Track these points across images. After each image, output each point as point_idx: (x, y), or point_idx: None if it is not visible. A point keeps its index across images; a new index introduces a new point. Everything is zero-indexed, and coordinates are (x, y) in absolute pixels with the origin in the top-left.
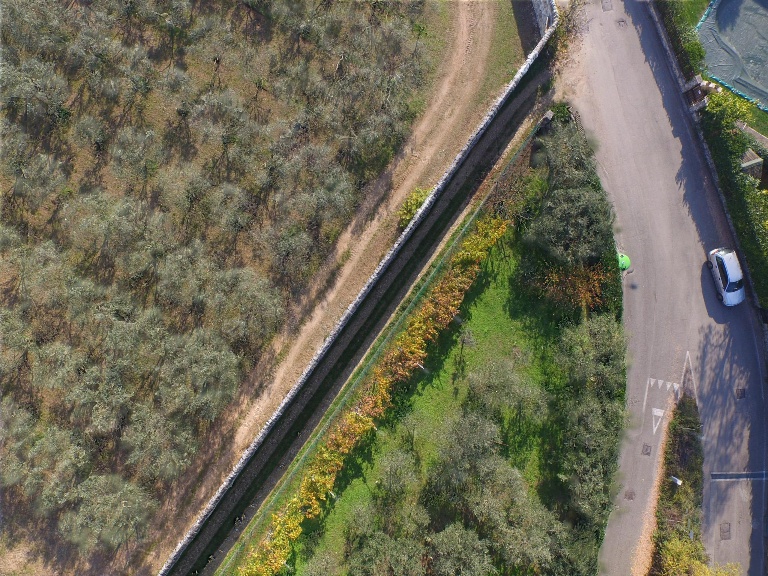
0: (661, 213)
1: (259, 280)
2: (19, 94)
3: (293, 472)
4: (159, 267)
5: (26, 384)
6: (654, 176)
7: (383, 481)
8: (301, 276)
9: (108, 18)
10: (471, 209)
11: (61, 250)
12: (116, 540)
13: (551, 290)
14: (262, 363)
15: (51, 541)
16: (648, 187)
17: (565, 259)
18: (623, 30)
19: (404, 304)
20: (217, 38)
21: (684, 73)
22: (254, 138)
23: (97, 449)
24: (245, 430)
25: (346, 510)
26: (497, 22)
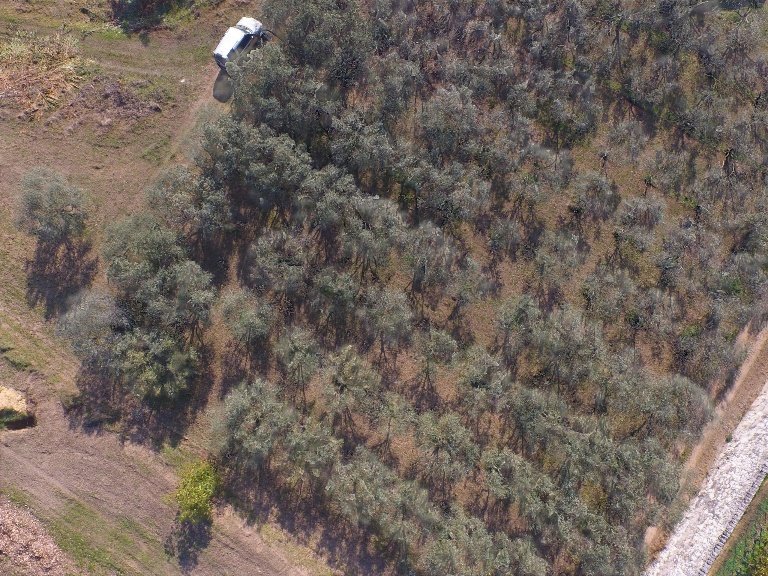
0: None
1: (659, 379)
2: None
3: None
4: (560, 365)
5: (438, 482)
6: None
7: None
8: (701, 376)
9: (490, 112)
10: None
11: (463, 347)
12: None
13: None
14: None
15: None
16: None
17: None
18: None
19: None
20: (601, 133)
21: None
22: (645, 235)
23: (514, 549)
24: (654, 530)
25: None
26: None
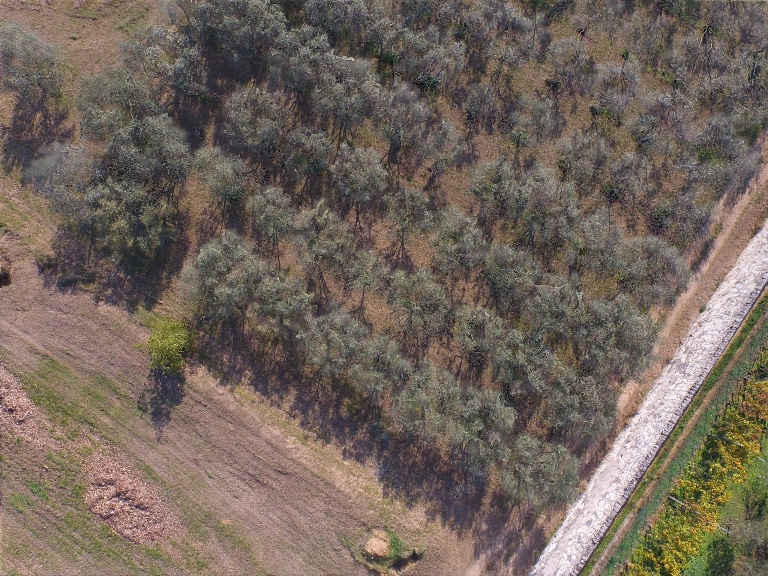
0: None
1: (634, 250)
2: None
3: (685, 440)
4: (535, 236)
5: (412, 348)
6: None
7: None
8: (675, 247)
9: None
10: None
11: (438, 217)
12: (509, 502)
13: None
14: None
15: (447, 501)
16: None
17: None
18: None
19: None
20: (579, 10)
21: None
22: (622, 110)
23: (486, 413)
24: (626, 398)
25: None
26: None
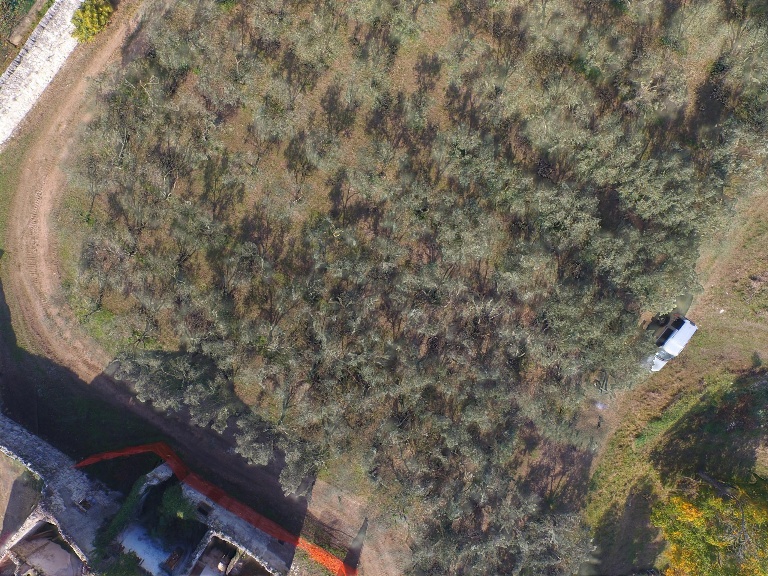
0: None
1: None
2: None
3: None
4: None
5: None
6: None
7: None
8: None
9: (410, 257)
10: None
11: (461, 5)
12: None
13: None
14: None
15: None
16: None
17: None
18: None
19: None
20: (298, 226)
21: None
22: None
23: None
24: None
25: None
26: (6, 222)
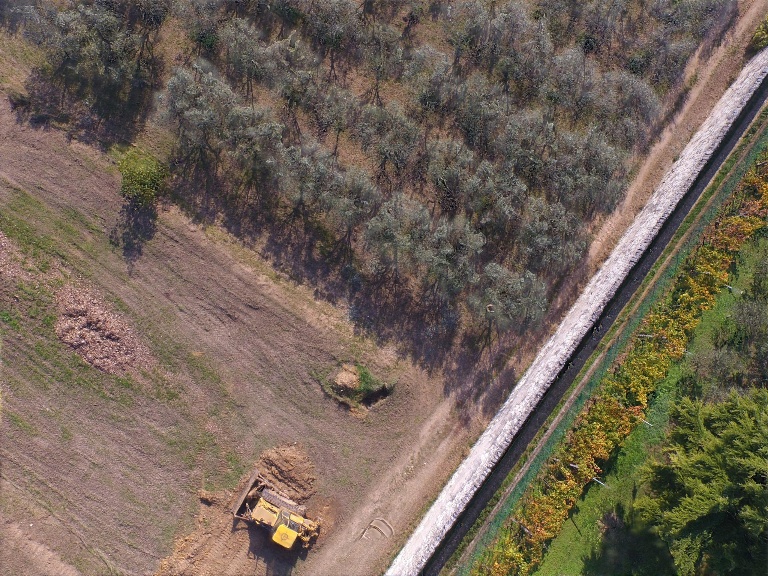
0: None
1: (608, 101)
2: None
3: (656, 282)
4: (510, 85)
5: (385, 193)
6: None
7: (748, 292)
8: (650, 98)
9: None
10: None
11: (413, 66)
12: (480, 343)
13: None
14: (613, 181)
15: (418, 341)
16: None
17: None
18: None
19: (755, 127)
20: None
21: None
22: None
23: (458, 256)
24: (598, 245)
25: (713, 317)
26: None
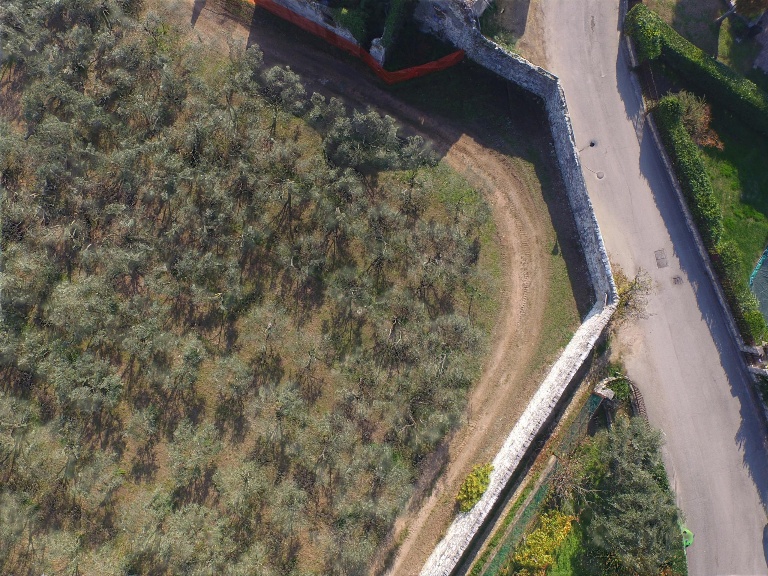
0: (721, 475)
1: (316, 562)
2: (75, 399)
3: None
4: None
5: None
6: (713, 437)
7: None
8: (359, 557)
9: (157, 282)
10: (529, 481)
11: (115, 534)
12: None
13: (614, 571)
14: None
15: None
16: (707, 448)
17: (634, 565)
18: (679, 287)
19: None
20: (268, 303)
21: (743, 336)
22: (308, 410)
23: None
24: None
25: None
26: (551, 282)
